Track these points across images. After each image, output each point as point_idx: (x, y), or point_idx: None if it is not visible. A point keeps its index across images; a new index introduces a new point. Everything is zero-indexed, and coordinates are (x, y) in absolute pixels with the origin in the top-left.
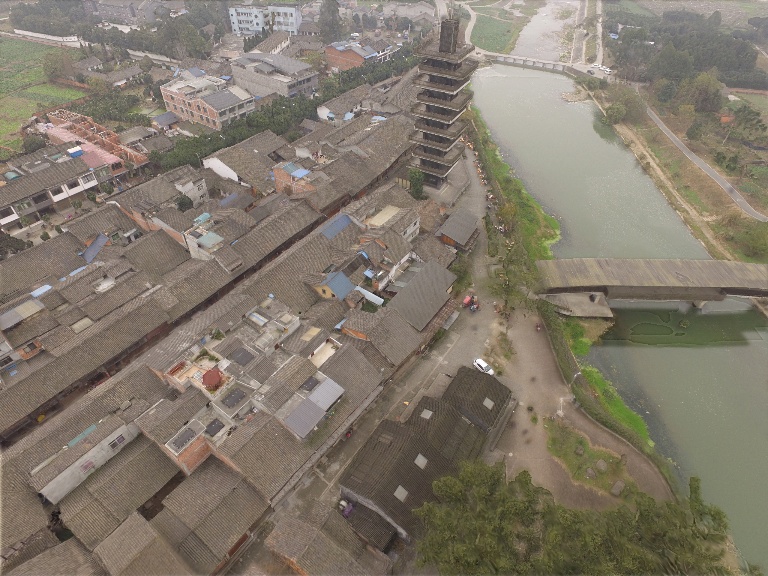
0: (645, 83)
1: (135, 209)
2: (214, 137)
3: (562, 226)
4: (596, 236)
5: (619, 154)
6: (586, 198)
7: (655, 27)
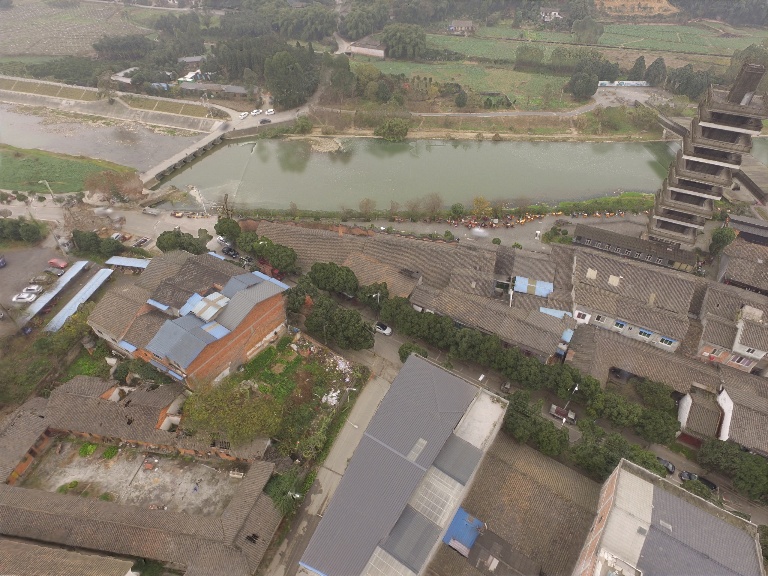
0: (317, 100)
1: None
2: None
3: (633, 191)
4: (635, 178)
5: (474, 145)
6: (574, 173)
7: (159, 59)
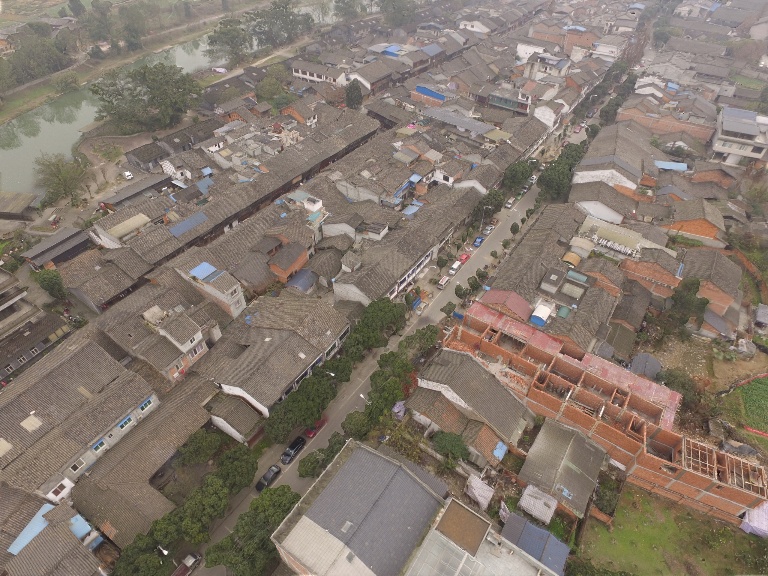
0: None
1: (383, 222)
2: (358, 412)
3: None
4: None
5: None
6: None
7: None
